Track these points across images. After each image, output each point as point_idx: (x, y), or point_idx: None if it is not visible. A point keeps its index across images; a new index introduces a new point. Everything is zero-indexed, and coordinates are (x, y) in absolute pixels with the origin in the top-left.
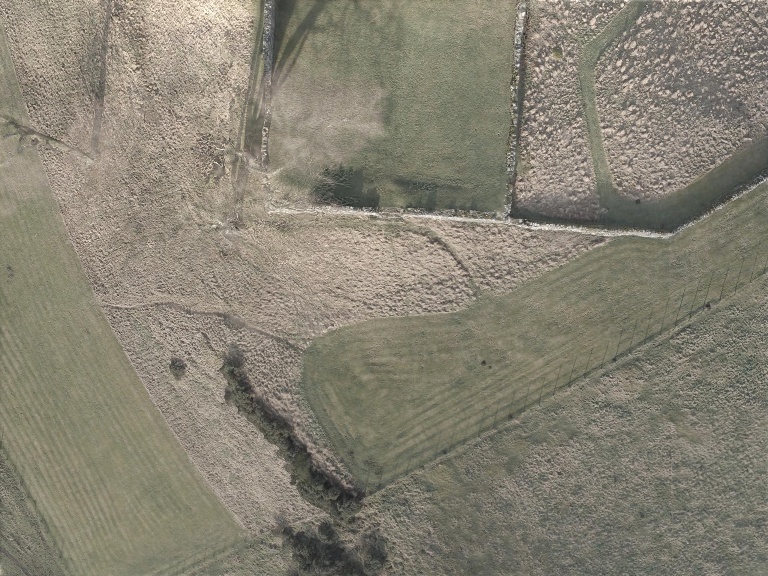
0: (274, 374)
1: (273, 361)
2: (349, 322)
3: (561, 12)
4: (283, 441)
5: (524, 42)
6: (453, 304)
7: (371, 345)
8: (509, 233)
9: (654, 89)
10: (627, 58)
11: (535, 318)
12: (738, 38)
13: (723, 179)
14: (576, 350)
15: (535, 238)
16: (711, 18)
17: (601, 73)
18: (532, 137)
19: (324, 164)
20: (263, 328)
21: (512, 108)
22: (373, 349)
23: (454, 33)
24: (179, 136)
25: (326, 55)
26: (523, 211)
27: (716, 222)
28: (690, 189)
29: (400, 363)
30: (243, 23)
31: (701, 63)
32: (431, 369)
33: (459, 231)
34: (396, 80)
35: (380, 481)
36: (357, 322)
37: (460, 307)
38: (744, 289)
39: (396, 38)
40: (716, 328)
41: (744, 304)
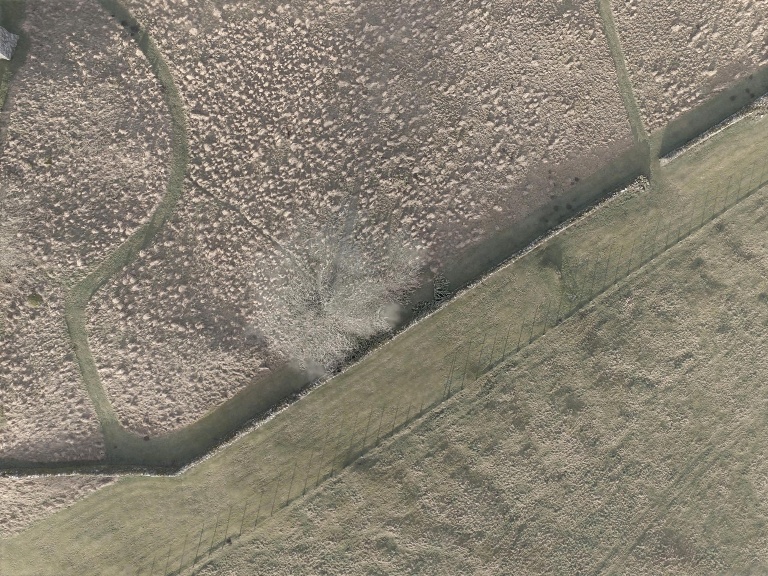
0: None
1: None
2: None
3: (39, 257)
4: None
5: None
6: None
7: None
8: None
9: (158, 323)
10: (126, 294)
11: (48, 560)
12: (259, 262)
13: (238, 411)
14: None
15: (28, 485)
16: (229, 243)
17: (92, 314)
18: (4, 390)
19: None
20: None
21: None
22: None
23: None
24: None
25: None
26: (9, 460)
27: (231, 456)
28: (201, 423)
29: None
30: None
31: (216, 291)
32: None
33: None
34: None
35: None
36: None
37: None
38: (266, 523)
39: None
40: (240, 563)
41: (268, 537)
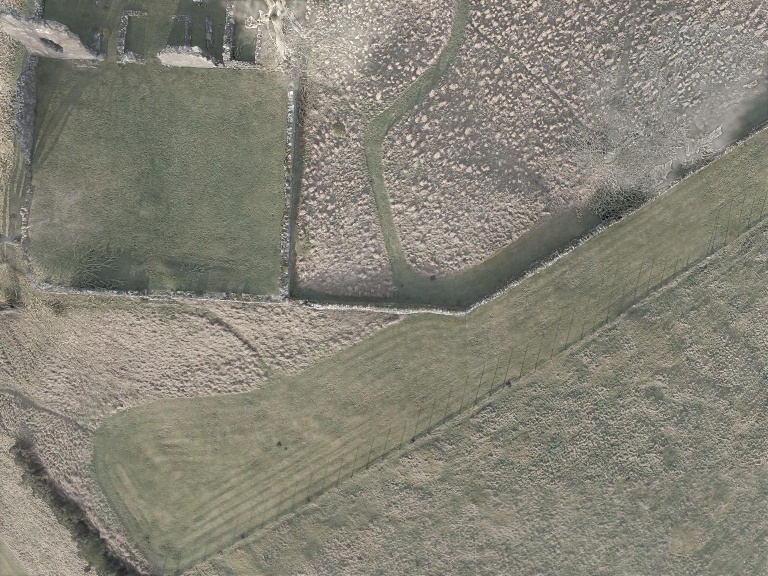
0: (64, 456)
1: (63, 442)
2: (138, 403)
3: (343, 87)
4: (72, 527)
5: (302, 118)
6: (243, 384)
7: (162, 426)
8: (294, 313)
9: (447, 163)
10: (418, 132)
11: (330, 398)
12: (538, 110)
13: (521, 254)
14: (373, 430)
15: (322, 318)
16: (510, 90)
17: (389, 148)
18: (311, 216)
19: (90, 245)
20: (52, 408)
21: (285, 188)
22: (165, 430)
23: (227, 110)
24: None
25: (92, 132)
26: (307, 291)
27: (514, 298)
28: (487, 265)
29: (193, 445)
30: (6, 97)
31: (499, 136)
32: (225, 451)
33: (239, 312)
34: (168, 157)
35: (178, 567)
36: (146, 403)
37: (251, 387)
38: (545, 366)
39: (167, 114)
40: (518, 406)
41: (546, 381)
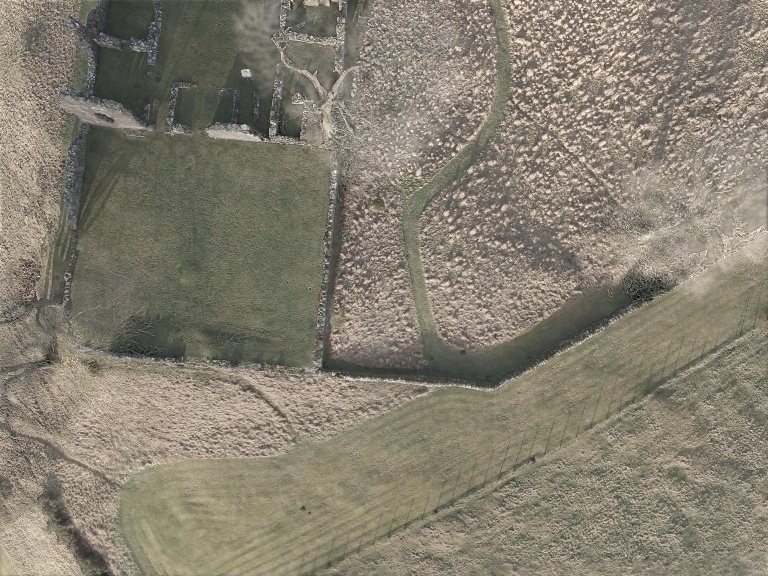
0: (91, 508)
1: (90, 494)
2: (166, 460)
3: (384, 163)
4: None
5: (343, 194)
6: (271, 449)
7: (189, 484)
8: (325, 383)
9: (483, 240)
10: (455, 208)
11: (356, 466)
12: (574, 188)
13: (551, 331)
14: (397, 500)
15: (353, 388)
16: (547, 167)
17: (426, 224)
18: (347, 290)
19: (130, 311)
20: (81, 460)
21: (324, 263)
22: (191, 488)
23: (270, 183)
24: (3, 259)
25: (137, 199)
26: (339, 362)
27: (543, 375)
28: (517, 341)
29: (218, 504)
30: (55, 162)
31: (534, 213)
32: (249, 512)
33: (272, 381)
34: (210, 227)
35: None
36: (174, 461)
37: (279, 452)
38: (570, 443)
39: (211, 184)
40: (541, 482)
41: (570, 458)
